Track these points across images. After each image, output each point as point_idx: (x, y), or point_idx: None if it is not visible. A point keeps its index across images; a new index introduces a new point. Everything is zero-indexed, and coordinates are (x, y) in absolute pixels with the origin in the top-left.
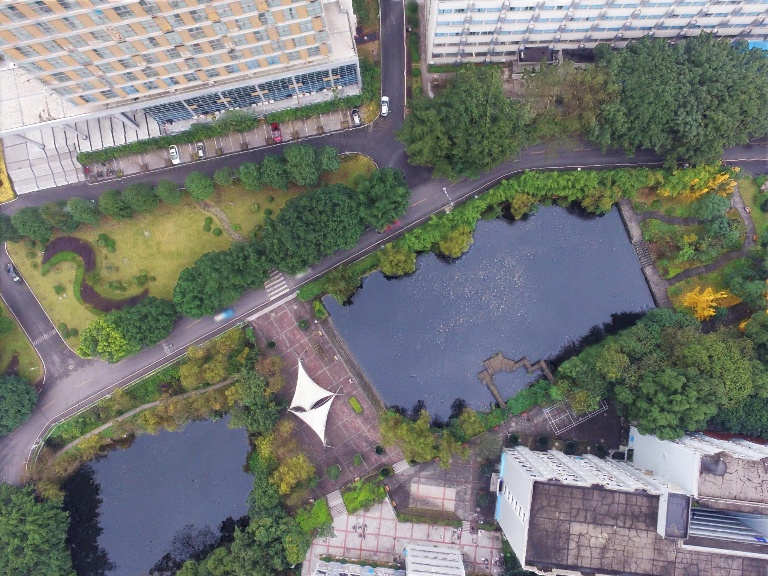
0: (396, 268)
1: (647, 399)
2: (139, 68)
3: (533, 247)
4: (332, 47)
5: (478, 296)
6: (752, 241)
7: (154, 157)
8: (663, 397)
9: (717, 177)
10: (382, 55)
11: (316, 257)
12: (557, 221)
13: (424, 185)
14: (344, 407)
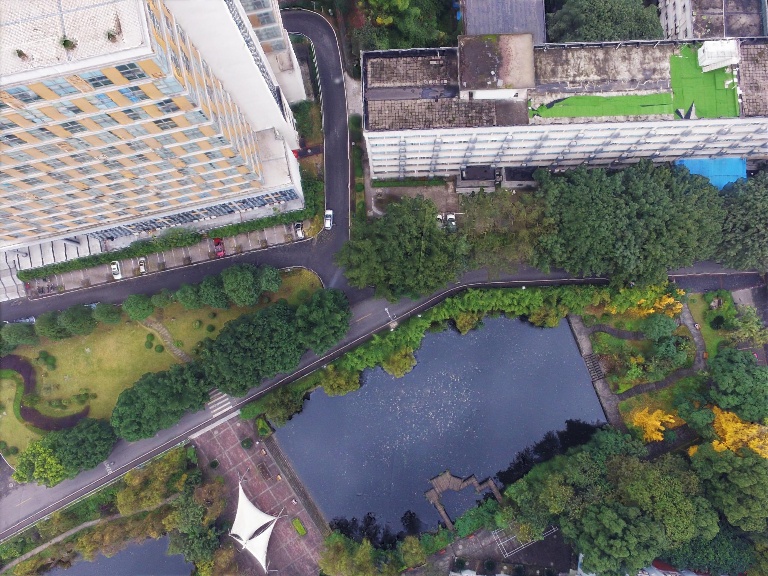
0: (338, 390)
1: (590, 537)
2: (63, 213)
3: (481, 360)
4: (268, 174)
5: (425, 411)
6: (702, 358)
7: (96, 272)
8: (604, 541)
9: (663, 298)
10: (326, 168)
11: (255, 381)
12: (505, 333)
13: (369, 300)
14: (288, 528)
